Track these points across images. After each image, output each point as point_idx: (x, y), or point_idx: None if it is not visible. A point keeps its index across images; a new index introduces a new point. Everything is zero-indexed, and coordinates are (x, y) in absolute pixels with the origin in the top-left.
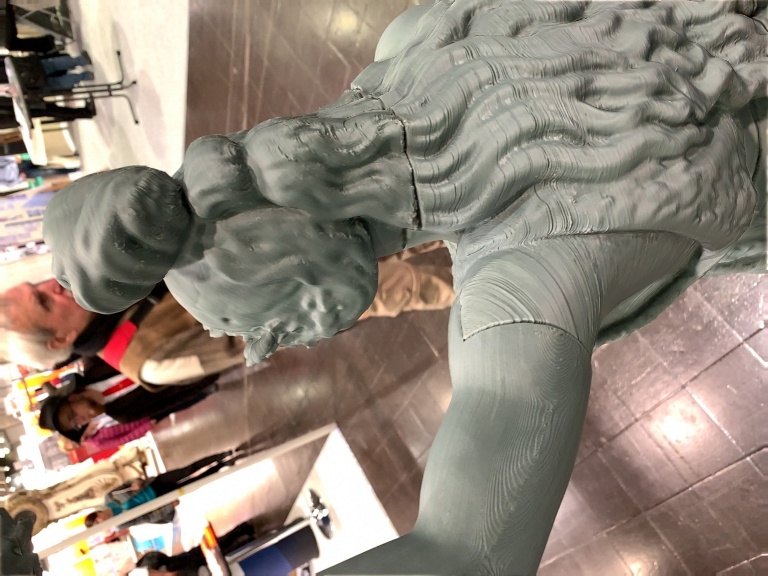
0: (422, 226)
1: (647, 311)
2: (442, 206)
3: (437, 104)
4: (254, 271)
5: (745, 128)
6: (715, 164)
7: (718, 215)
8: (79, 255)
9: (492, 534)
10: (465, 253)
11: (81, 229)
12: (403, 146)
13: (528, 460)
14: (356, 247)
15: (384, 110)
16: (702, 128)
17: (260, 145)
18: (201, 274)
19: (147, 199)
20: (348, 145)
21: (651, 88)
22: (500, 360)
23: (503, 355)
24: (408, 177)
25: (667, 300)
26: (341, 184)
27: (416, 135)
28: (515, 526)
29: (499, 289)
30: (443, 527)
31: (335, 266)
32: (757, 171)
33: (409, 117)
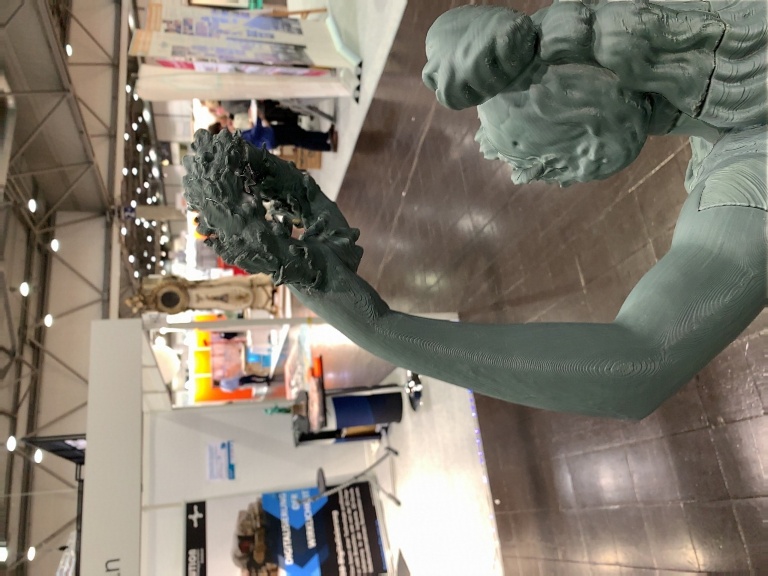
0: (700, 115)
1: None
2: (726, 103)
3: (760, 18)
4: (560, 111)
5: None
6: None
7: None
8: (457, 60)
9: (673, 338)
10: (723, 149)
11: (465, 42)
12: (716, 45)
13: (719, 302)
14: (640, 117)
15: (712, 12)
16: None
17: (609, 15)
18: (519, 102)
19: (518, 33)
20: (674, 33)
21: None
22: (726, 230)
23: (730, 227)
24: (708, 72)
25: None
26: (654, 62)
27: (731, 39)
28: (691, 340)
29: (746, 180)
30: (639, 322)
31: (618, 126)
32: None
33: (732, 23)
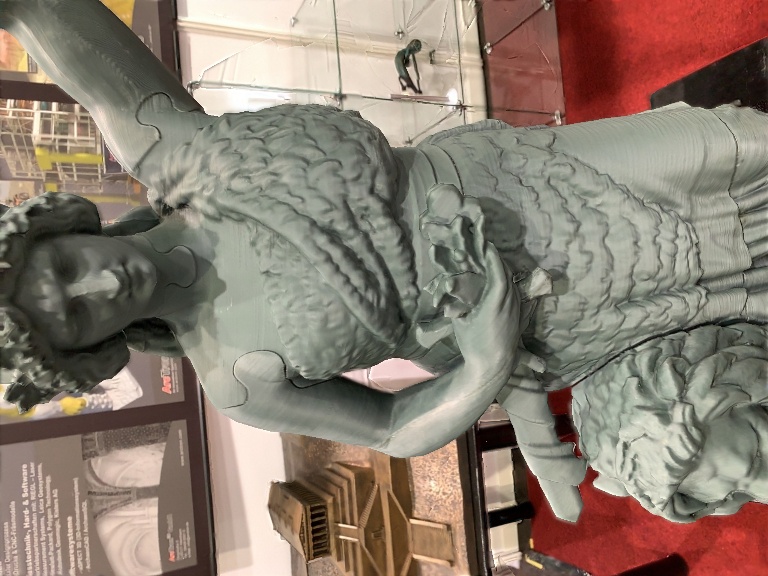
0: None
1: None
2: None
3: None
4: None
5: None
6: None
7: None
8: None
9: None
10: (149, 200)
11: None
12: None
13: None
14: None
15: None
16: None
17: None
18: None
19: None
20: None
21: None
22: None
23: None
24: None
25: None
26: None
27: None
28: None
29: None
30: None
31: None
32: None
33: None
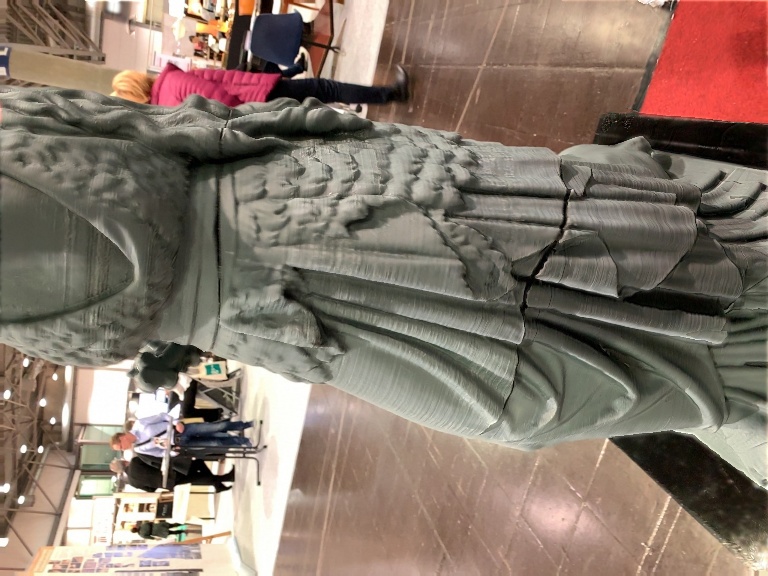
0: None
1: (89, 307)
2: None
3: None
4: None
5: (205, 180)
6: (58, 138)
7: (53, 171)
8: None
9: None
10: None
11: None
12: None
13: None
14: None
15: None
16: (68, 126)
17: None
18: None
19: None
20: None
21: (24, 96)
22: None
23: None
24: None
25: (109, 300)
26: None
27: None
28: None
29: None
30: None
31: None
32: (219, 213)
33: None
